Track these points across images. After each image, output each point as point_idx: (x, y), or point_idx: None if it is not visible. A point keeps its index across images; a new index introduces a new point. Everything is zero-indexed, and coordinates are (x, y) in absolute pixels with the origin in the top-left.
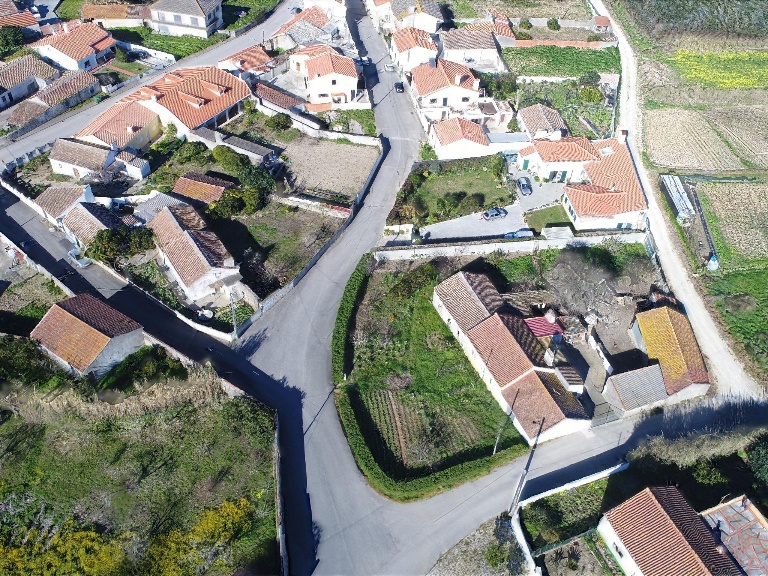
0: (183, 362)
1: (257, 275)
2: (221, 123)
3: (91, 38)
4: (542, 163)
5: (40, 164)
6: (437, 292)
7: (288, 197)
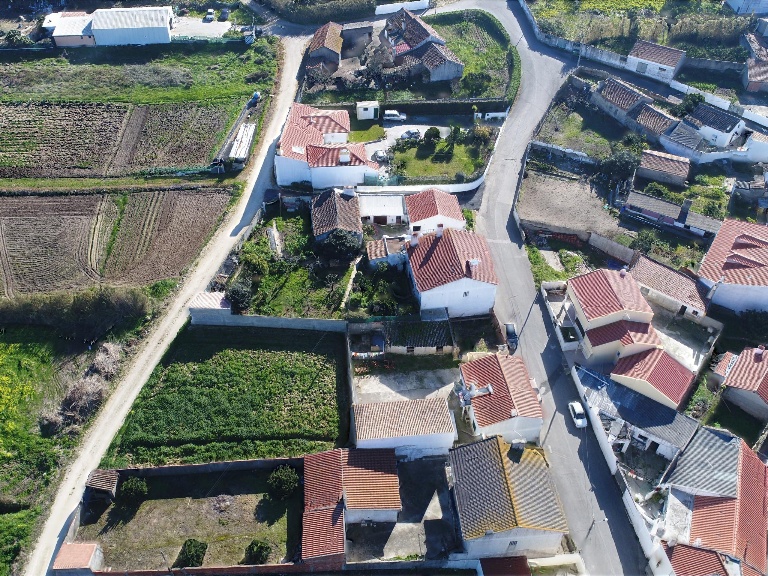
0: None
1: None
2: None
3: None
4: None
5: None
6: None
7: None
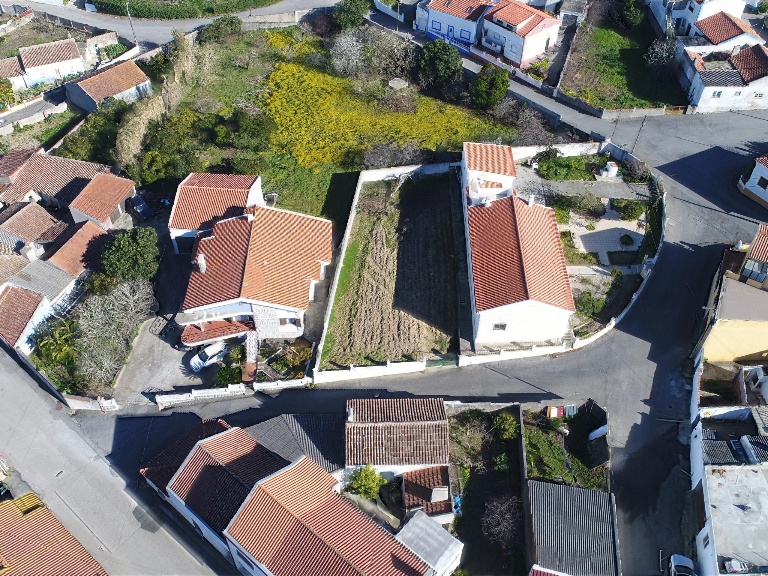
0: None
1: None
2: None
3: None
4: None
5: None
6: None
7: None
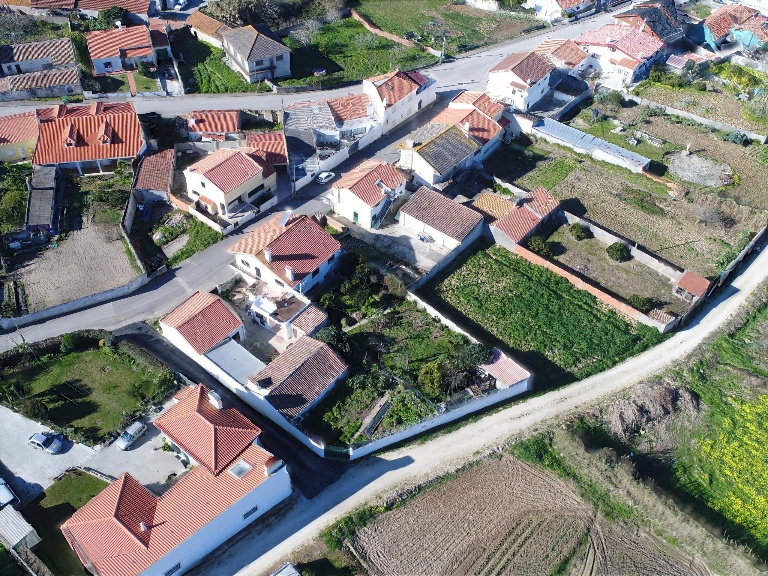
0: None
1: None
2: (93, 172)
3: (130, 42)
4: None
5: None
6: None
7: None
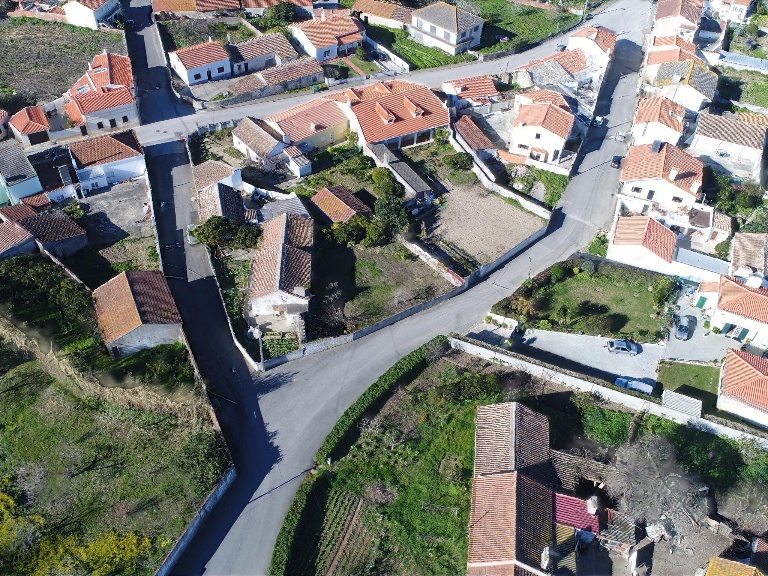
0: (196, 373)
1: (325, 313)
2: (407, 145)
3: (341, 30)
4: (718, 308)
5: (227, 135)
6: (479, 413)
7: (416, 243)
